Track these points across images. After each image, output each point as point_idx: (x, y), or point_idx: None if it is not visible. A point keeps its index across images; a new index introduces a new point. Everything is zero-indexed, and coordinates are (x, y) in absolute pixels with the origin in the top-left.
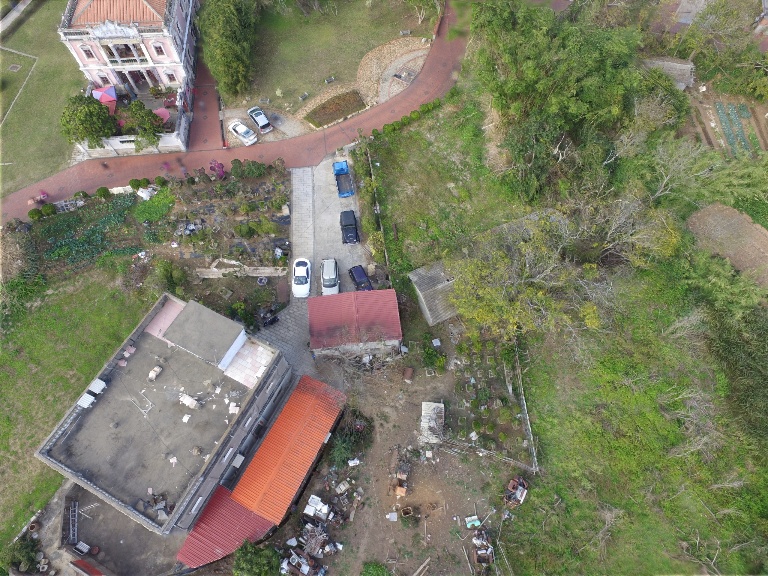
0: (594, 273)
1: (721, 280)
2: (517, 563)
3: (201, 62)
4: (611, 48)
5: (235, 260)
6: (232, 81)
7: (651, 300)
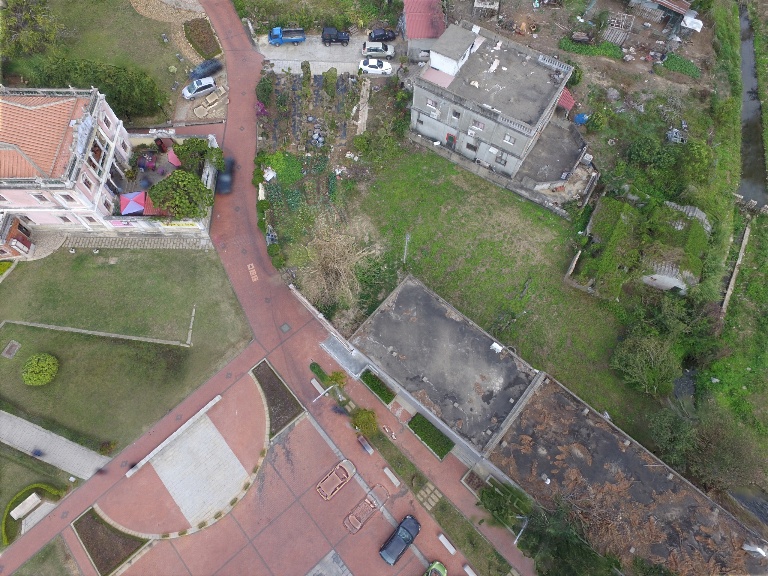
0: None
1: None
2: None
3: None
4: None
5: None
6: None
7: None
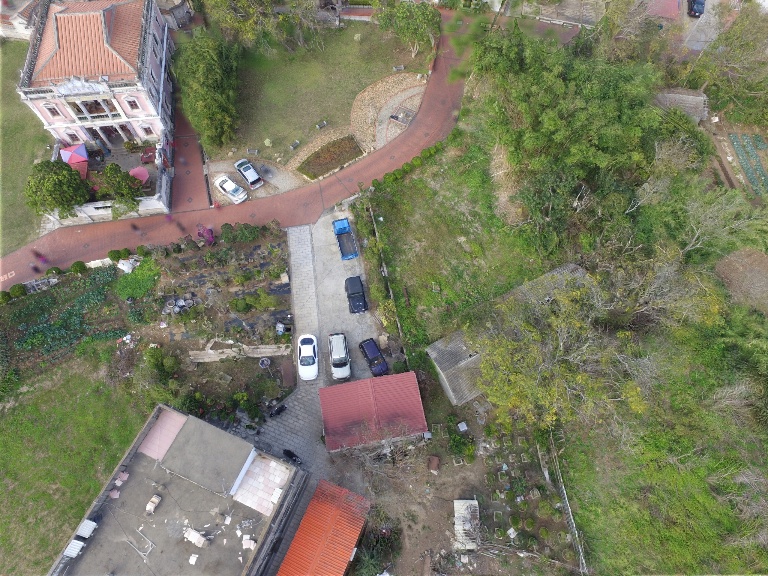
0: (628, 341)
1: (763, 342)
2: None
3: (179, 109)
4: (624, 86)
5: (233, 340)
6: (216, 133)
7: (686, 361)
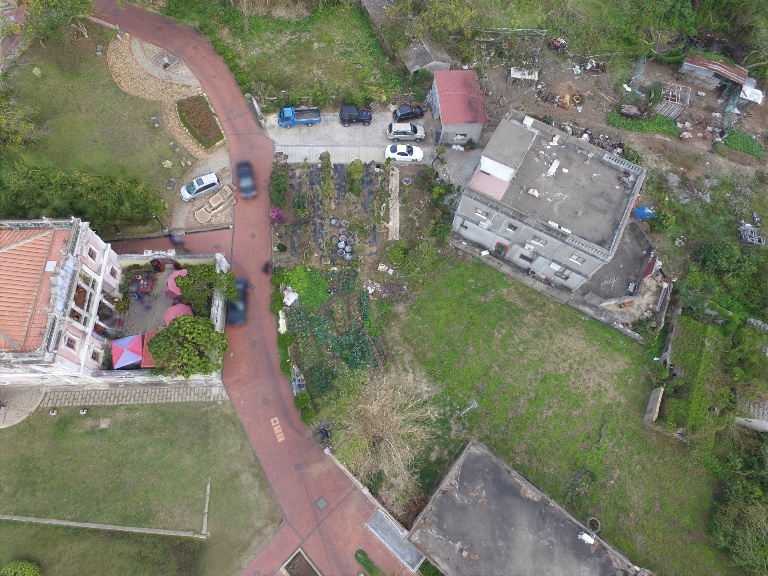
0: None
1: None
2: None
3: None
4: None
5: None
6: None
7: None
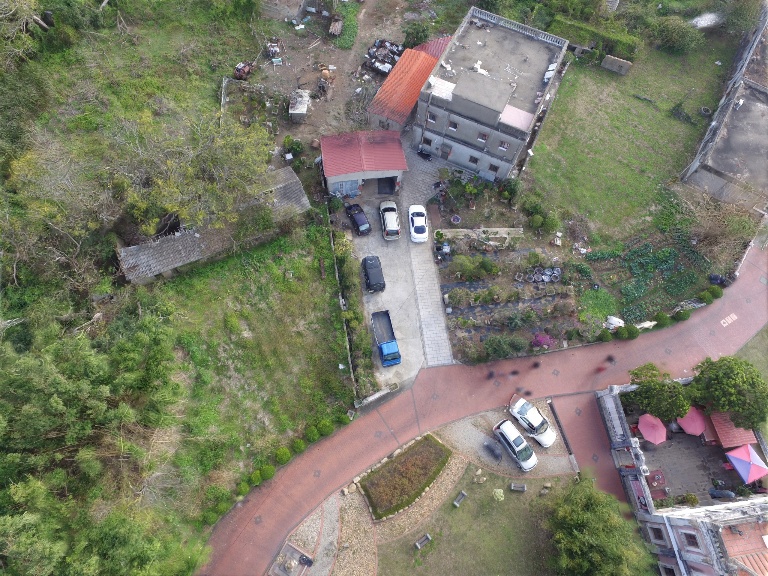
0: None
1: None
2: (252, 43)
3: None
4: None
5: None
6: None
7: None
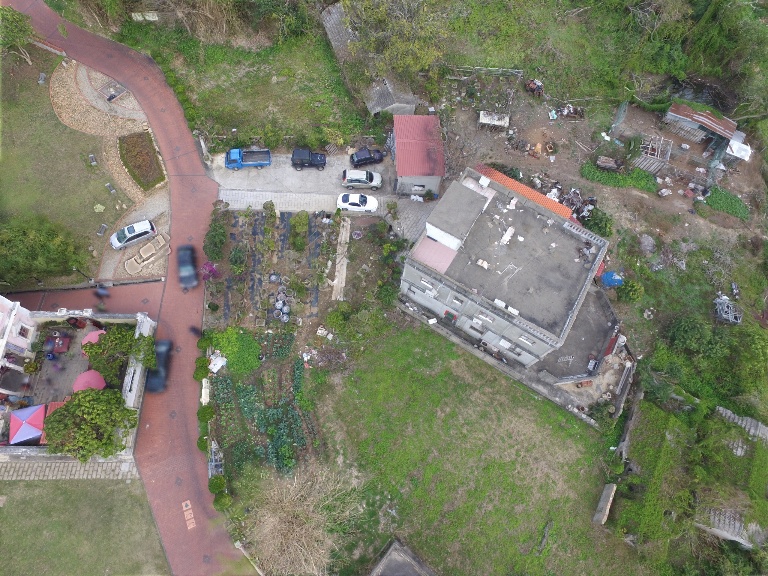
0: None
1: None
2: (574, 97)
3: None
4: None
5: None
6: None
7: None
